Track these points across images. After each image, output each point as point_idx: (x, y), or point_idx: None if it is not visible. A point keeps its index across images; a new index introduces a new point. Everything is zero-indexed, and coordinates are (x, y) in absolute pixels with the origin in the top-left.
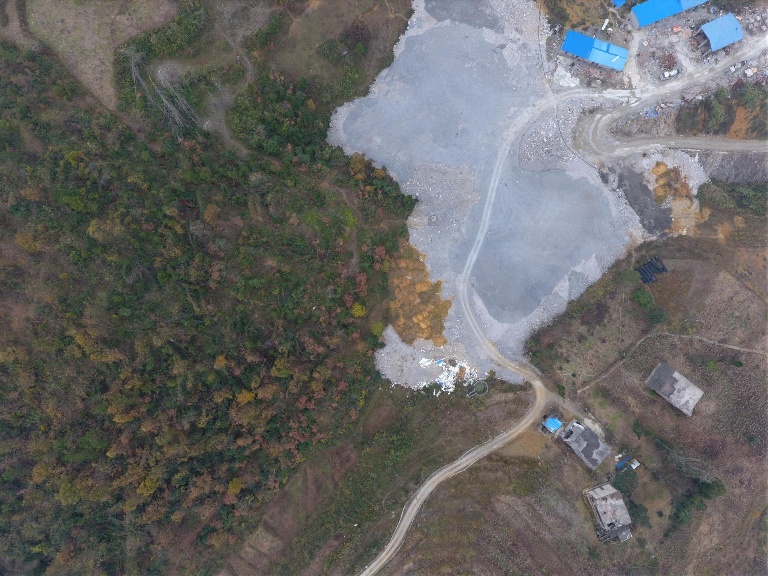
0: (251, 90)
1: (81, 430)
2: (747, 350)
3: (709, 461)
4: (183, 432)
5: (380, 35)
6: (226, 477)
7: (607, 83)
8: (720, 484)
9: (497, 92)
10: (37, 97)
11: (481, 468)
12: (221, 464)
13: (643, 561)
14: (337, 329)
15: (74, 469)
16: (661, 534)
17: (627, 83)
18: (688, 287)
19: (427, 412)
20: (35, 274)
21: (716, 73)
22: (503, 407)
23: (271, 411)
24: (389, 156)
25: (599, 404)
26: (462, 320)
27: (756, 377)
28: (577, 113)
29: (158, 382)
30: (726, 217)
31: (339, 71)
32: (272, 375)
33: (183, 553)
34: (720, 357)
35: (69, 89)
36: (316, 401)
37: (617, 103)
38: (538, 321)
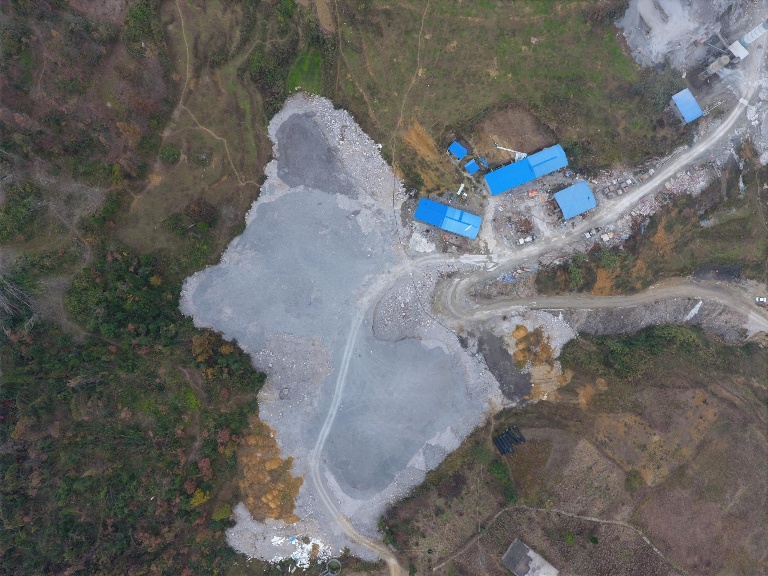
0: (88, 273)
1: None
2: (607, 521)
3: None
4: None
5: (230, 204)
6: None
7: (463, 248)
8: None
9: (351, 260)
10: None
11: None
12: None
13: None
14: (178, 517)
15: None
16: None
17: (484, 248)
18: (545, 458)
19: None
20: None
21: (573, 237)
22: None
23: None
24: (239, 328)
25: None
26: (315, 497)
27: (616, 549)
28: (435, 277)
29: None
30: (588, 380)
31: (186, 244)
32: None
33: None
34: (578, 530)
35: None
36: None
37: (474, 268)
38: (393, 496)
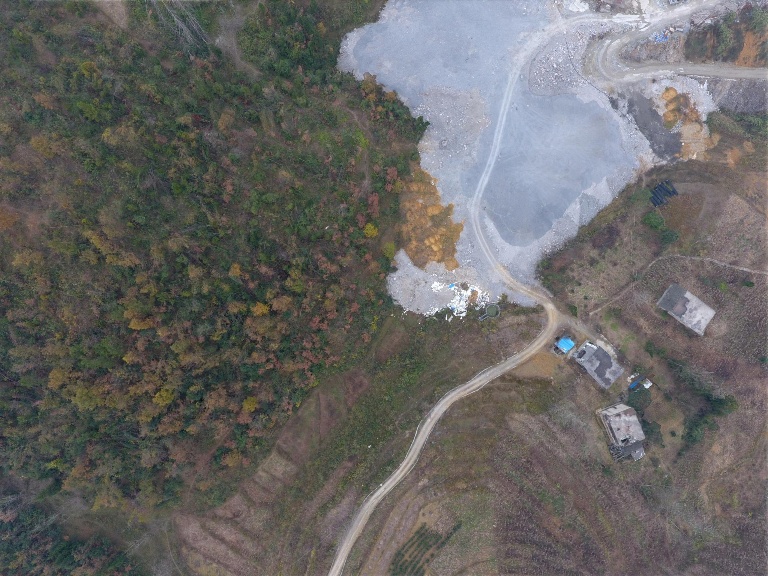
0: (262, 11)
1: (97, 337)
2: (758, 272)
3: None
4: (198, 345)
5: None
6: (240, 395)
7: (616, 8)
8: (733, 400)
9: (507, 17)
10: (49, 11)
11: (494, 388)
12: (235, 383)
13: (656, 480)
14: (350, 249)
15: (90, 375)
16: (674, 454)
17: (636, 8)
18: (699, 209)
19: (439, 336)
20: (50, 180)
21: None
22: (515, 329)
23: (285, 325)
24: (400, 81)
25: (611, 326)
26: (474, 243)
27: (767, 299)
28: (586, 39)
29: (173, 292)
30: (736, 142)
31: None
32: (287, 285)
33: (197, 475)
34: (731, 278)
35: (81, 5)
36: (329, 322)
37: (626, 28)
38: (550, 244)
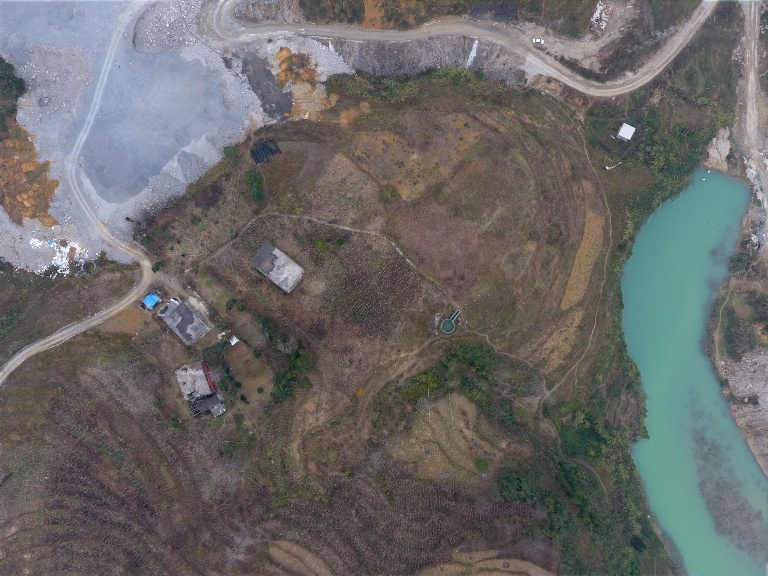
0: None
1: None
2: (359, 231)
3: (316, 340)
4: None
5: None
6: None
7: None
8: (300, 354)
9: None
10: None
11: (75, 343)
12: None
13: (240, 436)
14: None
15: None
16: (261, 411)
17: None
18: (299, 168)
19: None
20: None
21: None
22: (106, 285)
23: None
24: (1, 38)
25: (206, 283)
26: (71, 200)
27: (367, 257)
28: None
29: None
30: (352, 103)
31: None
32: None
33: None
34: (329, 237)
35: None
36: None
37: None
38: (149, 202)
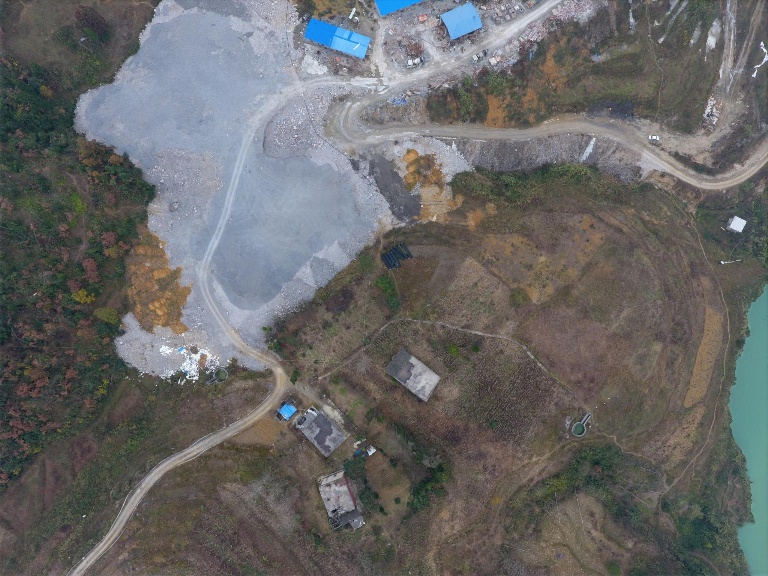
0: None
1: None
2: (491, 335)
3: (451, 447)
4: None
5: (123, 22)
6: None
7: (354, 71)
8: (445, 469)
9: (243, 79)
10: None
11: (212, 456)
12: None
13: (378, 549)
14: (62, 316)
15: None
16: (399, 521)
17: (374, 71)
18: (431, 273)
19: None
20: None
21: (462, 62)
22: (240, 394)
23: None
24: (131, 143)
25: (340, 391)
26: (203, 307)
27: (500, 362)
28: (327, 101)
29: None
30: (478, 204)
31: (78, 57)
32: None
33: None
34: (462, 342)
35: None
36: (41, 389)
37: (365, 91)
38: (280, 308)
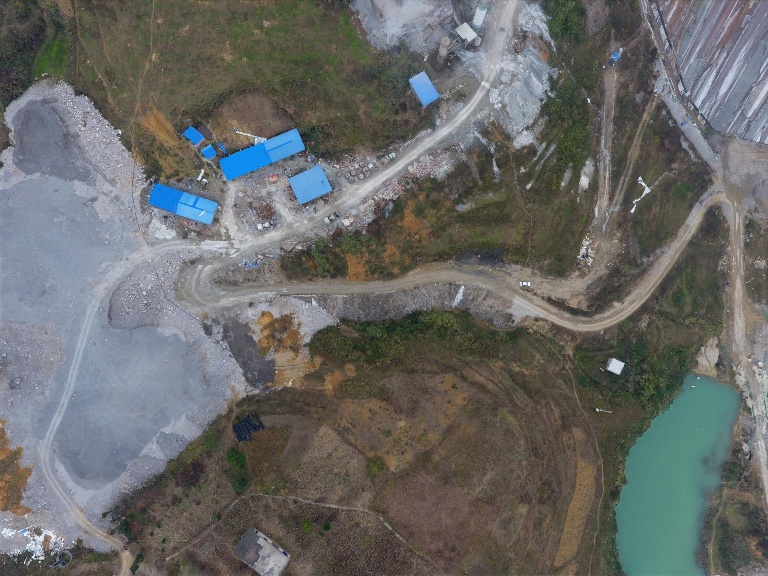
0: None
1: None
2: (346, 508)
3: None
4: None
5: None
6: None
7: (204, 235)
8: None
9: (87, 247)
10: None
11: None
12: None
13: None
14: None
15: None
16: None
17: (224, 234)
18: (283, 445)
19: None
20: None
21: (315, 222)
22: None
23: None
24: None
25: (188, 571)
26: (45, 487)
27: (355, 536)
28: (178, 264)
29: None
30: (337, 366)
31: None
32: None
33: None
34: (315, 517)
35: None
36: None
37: (216, 254)
38: (127, 485)
